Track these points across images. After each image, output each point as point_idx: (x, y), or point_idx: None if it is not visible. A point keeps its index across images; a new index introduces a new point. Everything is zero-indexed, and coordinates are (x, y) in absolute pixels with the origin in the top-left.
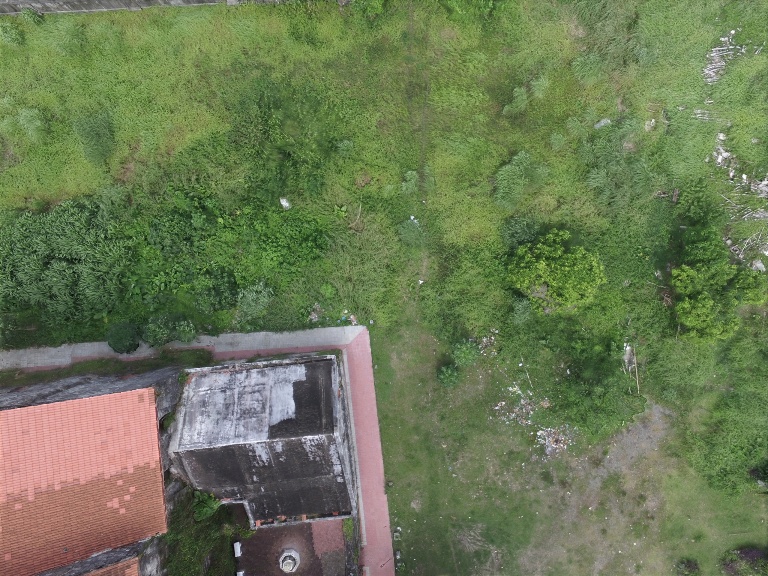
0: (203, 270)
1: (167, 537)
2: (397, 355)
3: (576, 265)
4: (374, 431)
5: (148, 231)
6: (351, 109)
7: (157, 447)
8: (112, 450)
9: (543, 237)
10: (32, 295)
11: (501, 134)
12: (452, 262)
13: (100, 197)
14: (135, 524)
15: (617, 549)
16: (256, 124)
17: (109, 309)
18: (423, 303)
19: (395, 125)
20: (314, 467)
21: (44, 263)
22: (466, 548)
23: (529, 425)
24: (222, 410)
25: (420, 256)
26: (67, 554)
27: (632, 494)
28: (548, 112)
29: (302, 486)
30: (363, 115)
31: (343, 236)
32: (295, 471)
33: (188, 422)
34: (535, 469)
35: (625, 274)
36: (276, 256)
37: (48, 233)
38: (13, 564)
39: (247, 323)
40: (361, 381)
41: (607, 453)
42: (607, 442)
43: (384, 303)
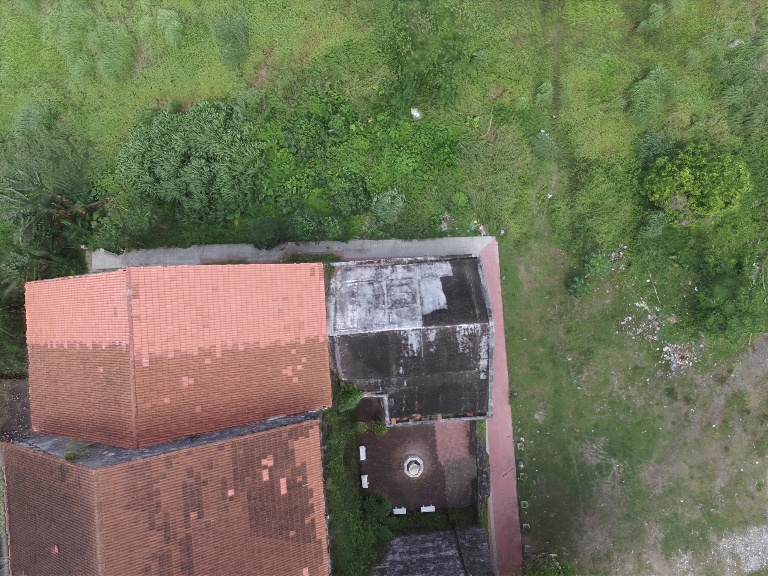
0: (335, 175)
1: (328, 415)
2: (525, 267)
3: (725, 171)
4: (500, 342)
5: (281, 135)
6: (484, 21)
7: (325, 322)
8: (287, 319)
9: (681, 150)
10: (169, 191)
11: (634, 51)
12: (583, 176)
13: (234, 100)
14: (306, 394)
15: (739, 467)
16: (390, 33)
17: (242, 210)
18: (554, 215)
19: (527, 39)
20: (461, 360)
21: (181, 160)
22: (588, 461)
23: (655, 341)
24: (373, 300)
25: (550, 170)
26: (248, 414)
27: (756, 413)
28: (682, 31)
29: (444, 382)
30: (497, 27)
31: (477, 145)
32: (442, 364)
33: (340, 310)
34: (660, 385)
35: (756, 194)
36: (411, 162)
37: (186, 131)
38: (203, 417)
39: (378, 229)
40: (488, 291)
41: (732, 371)
42: (732, 361)
43: (515, 214)
